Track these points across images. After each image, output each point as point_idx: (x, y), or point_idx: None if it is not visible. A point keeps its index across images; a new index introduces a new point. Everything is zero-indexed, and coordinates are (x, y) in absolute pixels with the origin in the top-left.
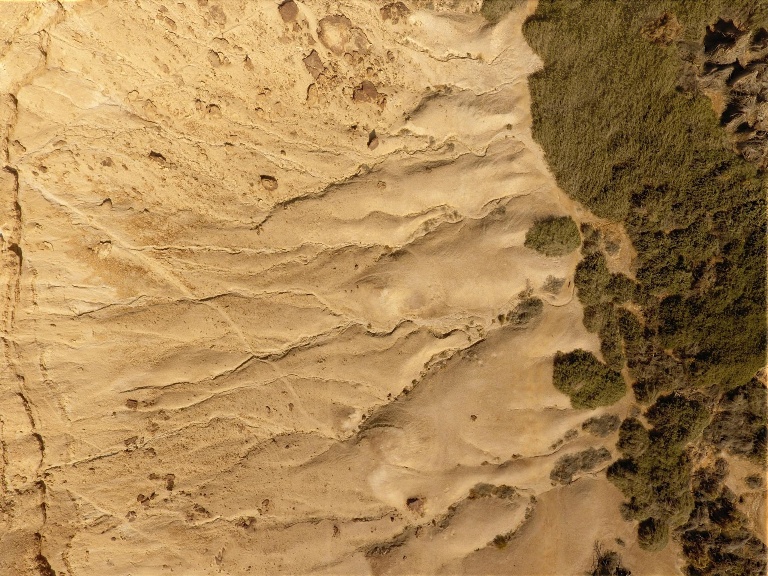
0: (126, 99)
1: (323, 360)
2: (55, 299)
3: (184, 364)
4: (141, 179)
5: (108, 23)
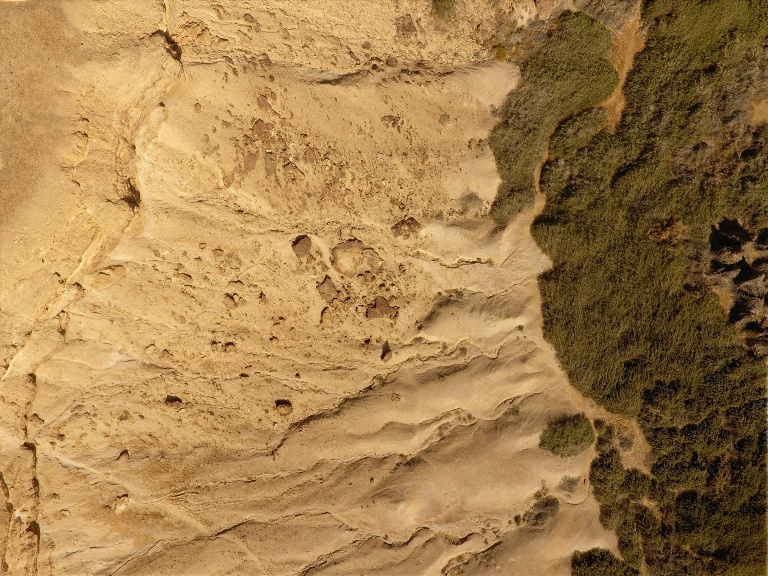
0: (143, 354)
1: None
2: (72, 566)
3: None
4: (157, 424)
5: (126, 291)
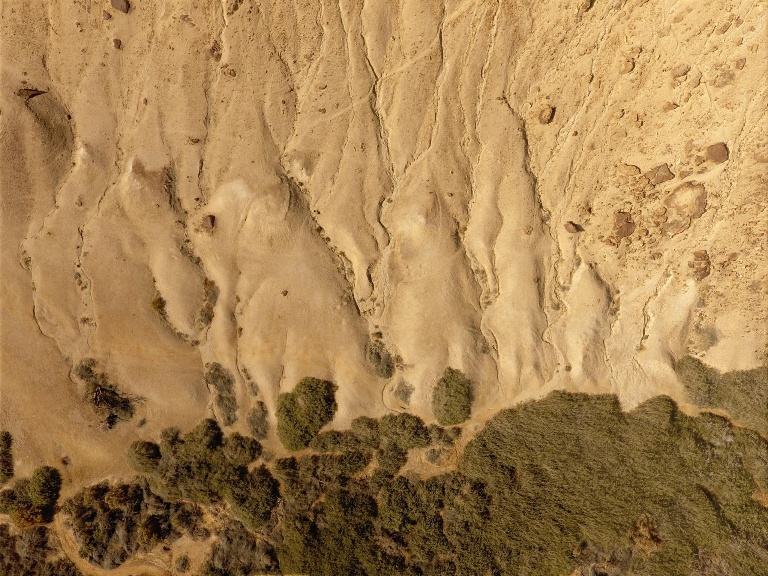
0: None
1: (363, 149)
2: None
3: (381, 6)
4: None
5: None
